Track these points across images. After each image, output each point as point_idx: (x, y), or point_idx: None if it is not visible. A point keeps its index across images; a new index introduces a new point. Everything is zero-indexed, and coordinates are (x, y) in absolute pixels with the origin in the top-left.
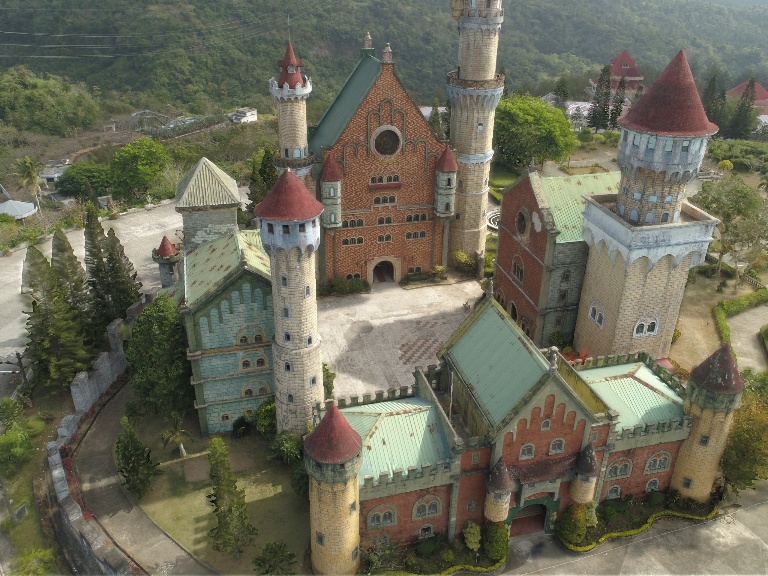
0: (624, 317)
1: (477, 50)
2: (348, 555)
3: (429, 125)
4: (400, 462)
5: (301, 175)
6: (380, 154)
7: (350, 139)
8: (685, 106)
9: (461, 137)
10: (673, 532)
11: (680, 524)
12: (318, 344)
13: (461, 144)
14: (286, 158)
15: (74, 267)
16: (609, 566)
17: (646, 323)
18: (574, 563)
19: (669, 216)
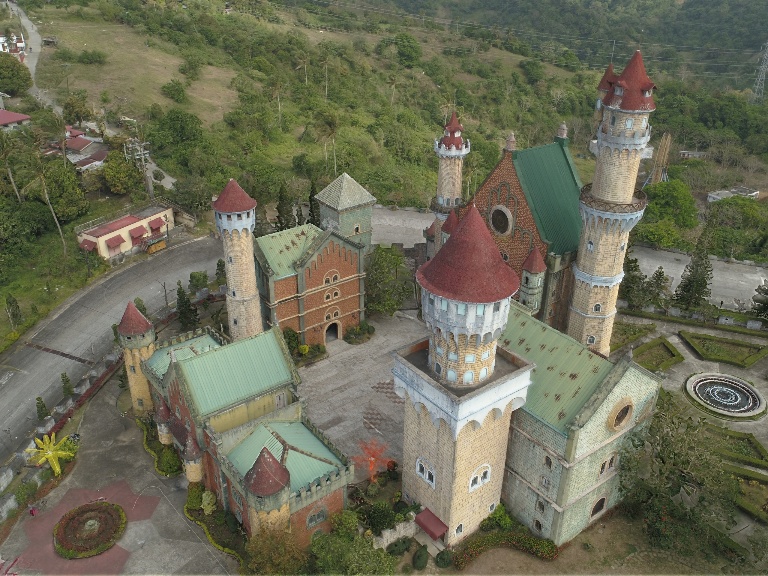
0: (408, 443)
1: (599, 165)
2: (135, 398)
3: (535, 220)
4: (165, 370)
5: (442, 219)
6: (495, 229)
7: (478, 206)
8: (445, 260)
9: (579, 248)
10: (225, 570)
11: (236, 575)
12: (240, 300)
13: (578, 255)
14: (436, 201)
15: (288, 211)
16: (177, 532)
17: (426, 468)
18: (176, 513)
19: (442, 370)
